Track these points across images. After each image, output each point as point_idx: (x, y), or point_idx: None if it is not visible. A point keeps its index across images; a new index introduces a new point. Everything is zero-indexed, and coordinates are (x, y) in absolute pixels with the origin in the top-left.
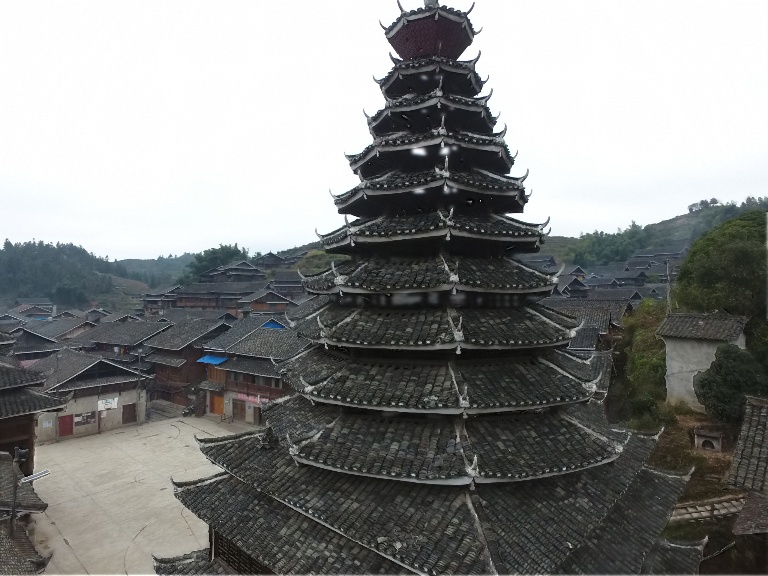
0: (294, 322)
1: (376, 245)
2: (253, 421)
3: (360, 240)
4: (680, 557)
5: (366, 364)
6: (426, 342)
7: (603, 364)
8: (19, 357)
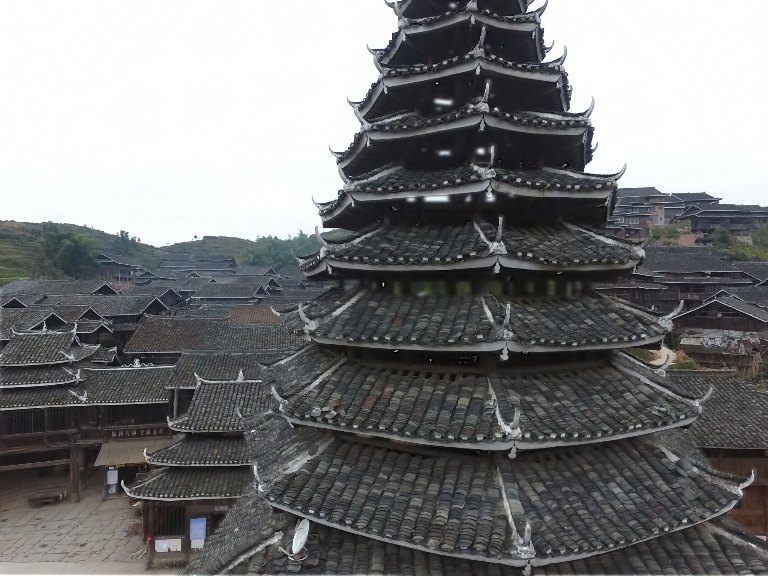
0: (315, 321)
1: (512, 201)
2: None
3: (502, 189)
4: None
5: (514, 377)
6: (640, 336)
7: None
8: None
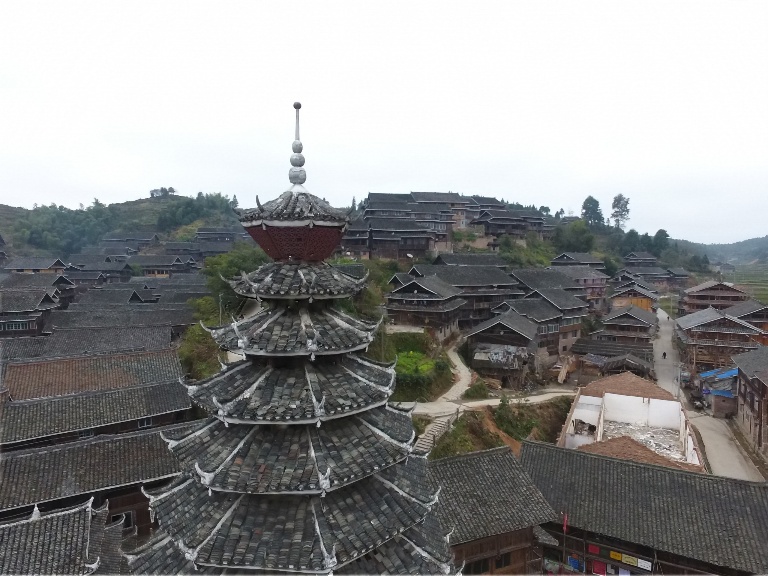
0: None
1: None
2: None
3: None
4: None
5: None
6: None
7: None
8: None
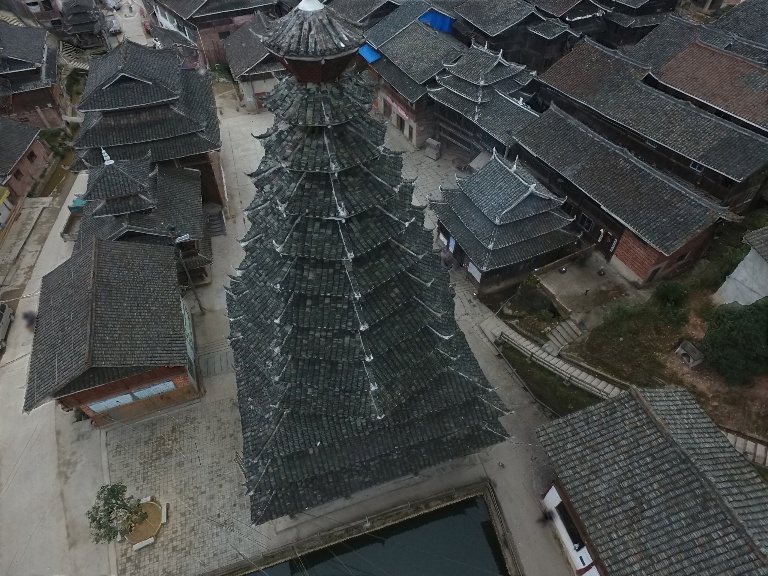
0: None
1: None
2: (396, 125)
3: None
4: (484, 437)
5: None
6: None
7: (700, 221)
8: (231, 14)
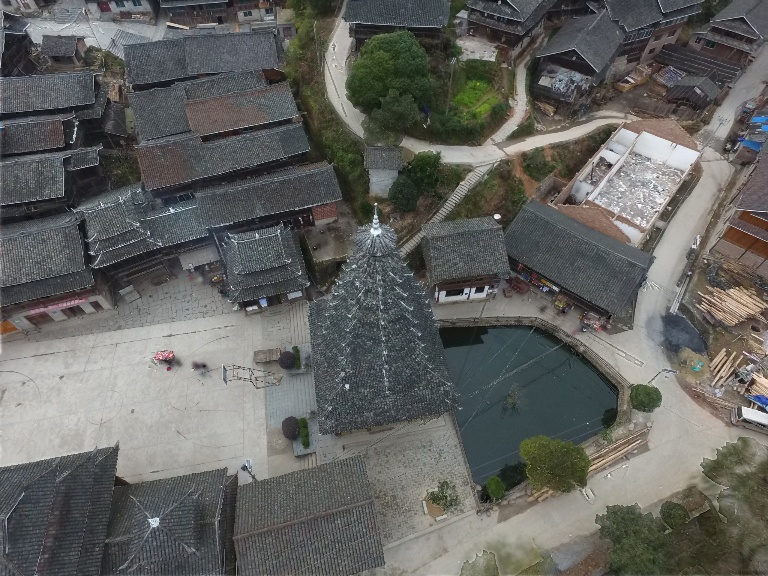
0: None
1: None
2: (67, 318)
3: None
4: None
5: None
6: None
7: (332, 177)
8: None
